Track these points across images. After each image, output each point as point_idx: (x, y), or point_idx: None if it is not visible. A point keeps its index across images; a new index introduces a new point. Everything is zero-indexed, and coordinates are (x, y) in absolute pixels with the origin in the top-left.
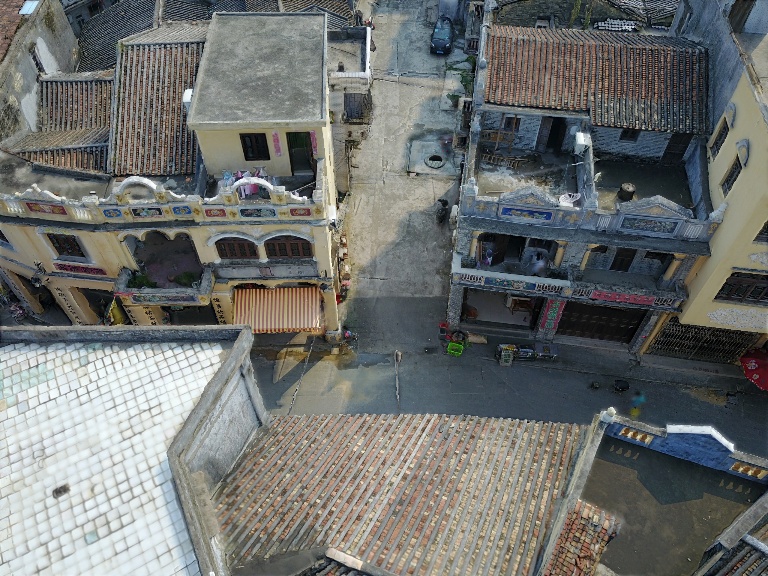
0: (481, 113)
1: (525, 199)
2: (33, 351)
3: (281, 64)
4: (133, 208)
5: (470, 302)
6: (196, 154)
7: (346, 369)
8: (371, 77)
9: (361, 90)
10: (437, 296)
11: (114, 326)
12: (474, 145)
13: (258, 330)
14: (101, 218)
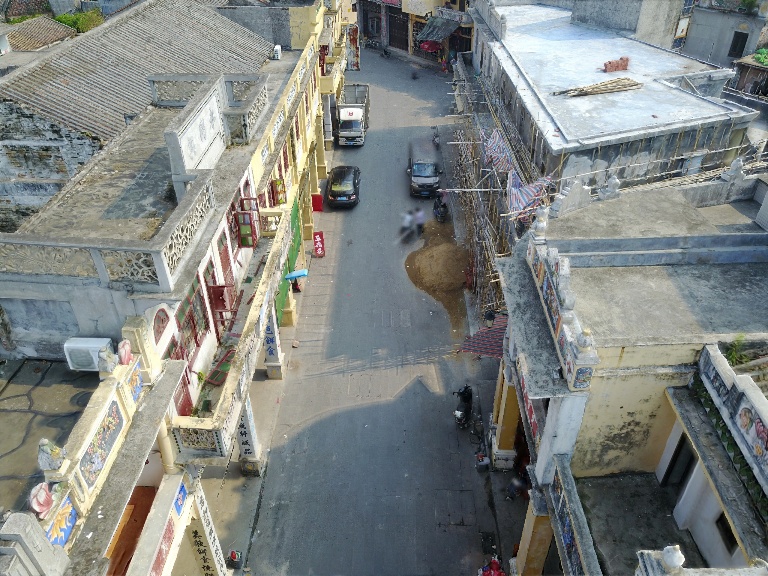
0: None
1: None
2: None
3: None
4: None
5: None
6: None
7: None
8: None
9: None
10: None
11: None
12: None
13: None
14: None
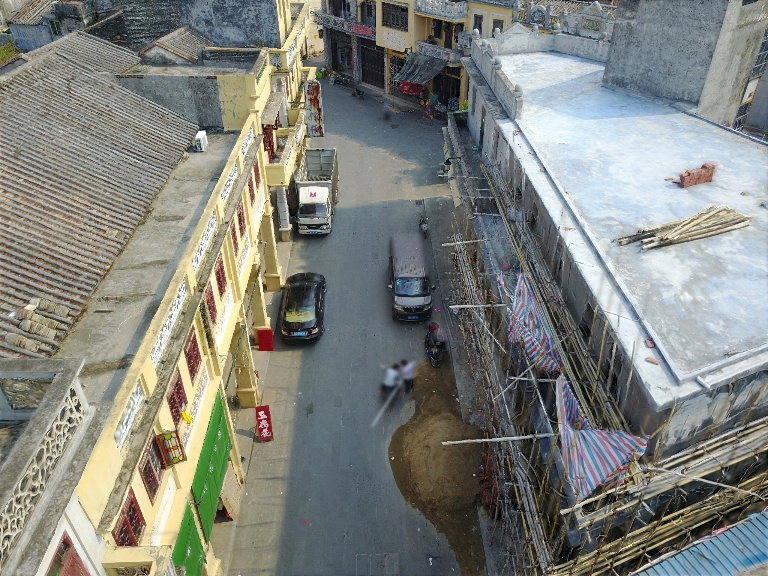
0: None
1: None
2: None
3: None
4: None
5: (348, 70)
6: None
7: None
8: None
9: None
10: None
11: None
12: None
13: None
14: None
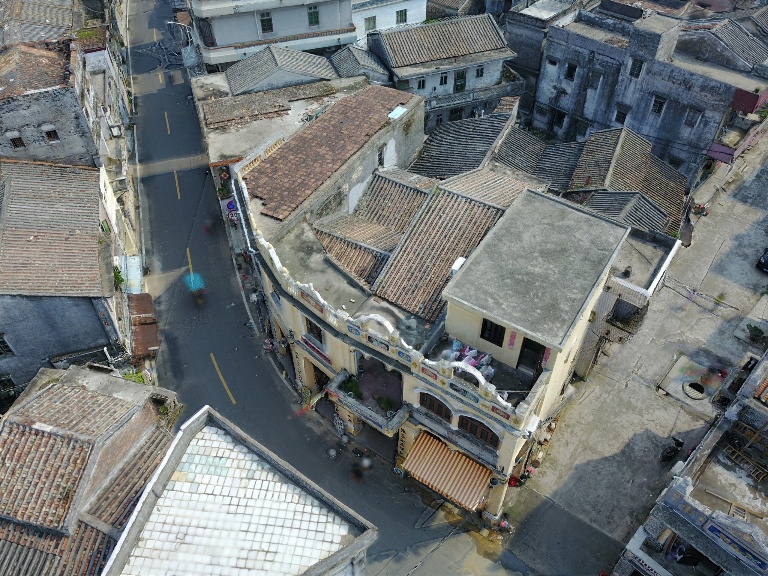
0: (744, 405)
1: (741, 533)
2: (226, 443)
3: (556, 267)
4: (370, 335)
5: None
6: (445, 307)
7: (484, 557)
8: (662, 283)
9: (636, 303)
10: (616, 539)
11: (283, 461)
12: (719, 433)
13: (422, 479)
14: (344, 330)
